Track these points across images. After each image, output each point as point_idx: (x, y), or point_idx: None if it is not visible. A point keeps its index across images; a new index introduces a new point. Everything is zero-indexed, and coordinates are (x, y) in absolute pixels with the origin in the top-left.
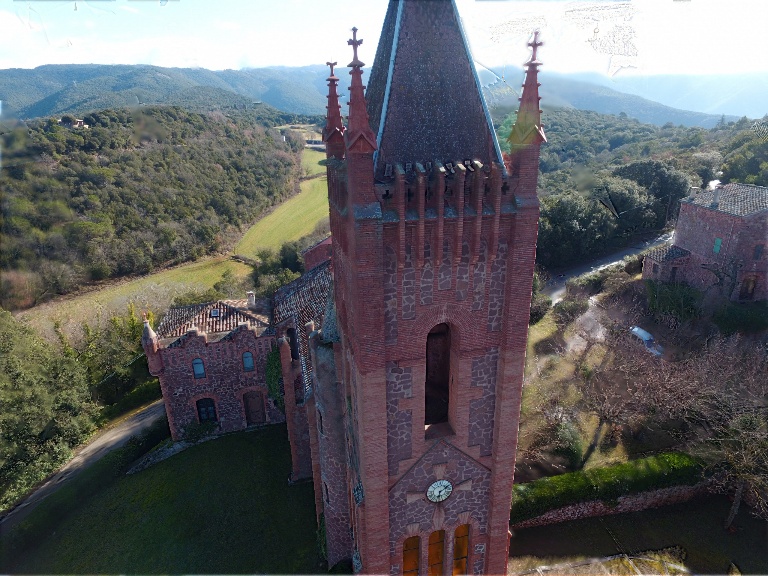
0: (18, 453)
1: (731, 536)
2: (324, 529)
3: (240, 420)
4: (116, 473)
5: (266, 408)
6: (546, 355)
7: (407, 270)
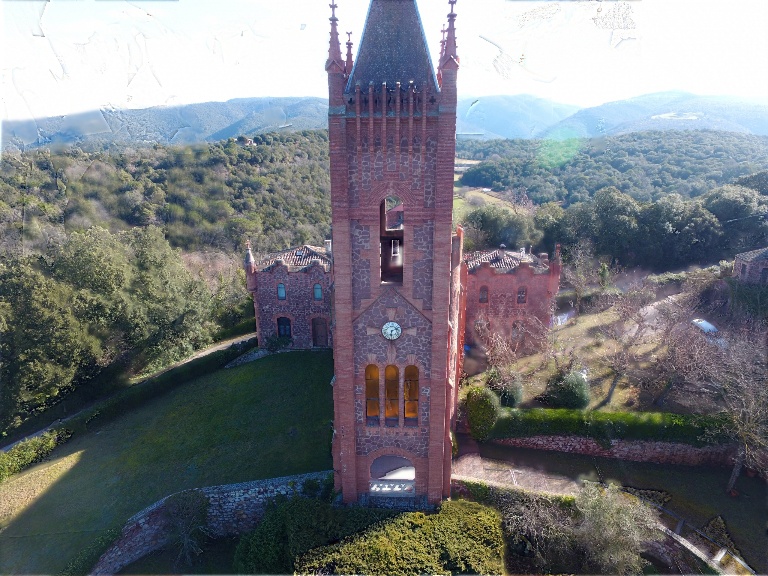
0: (159, 333)
1: (730, 498)
2: None
3: (308, 340)
4: (218, 366)
5: (328, 334)
6: None
7: (365, 154)
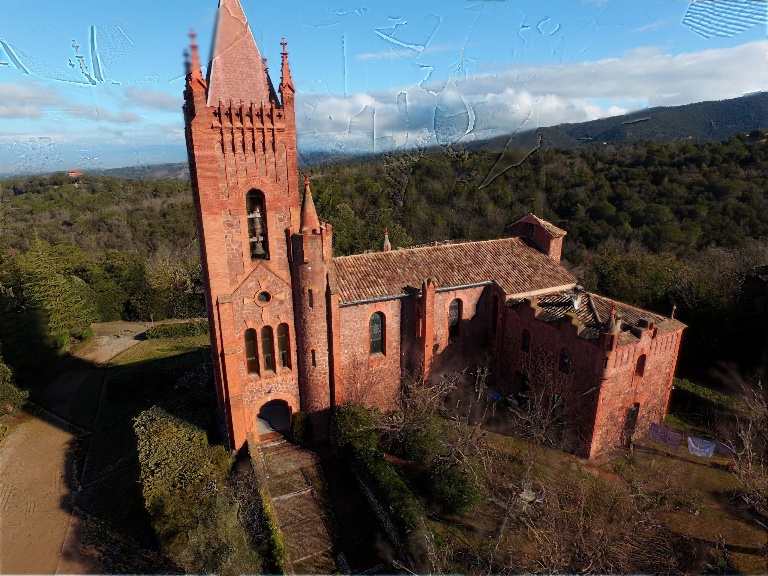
0: None
1: None
2: None
3: None
4: None
5: None
6: (729, 504)
7: None
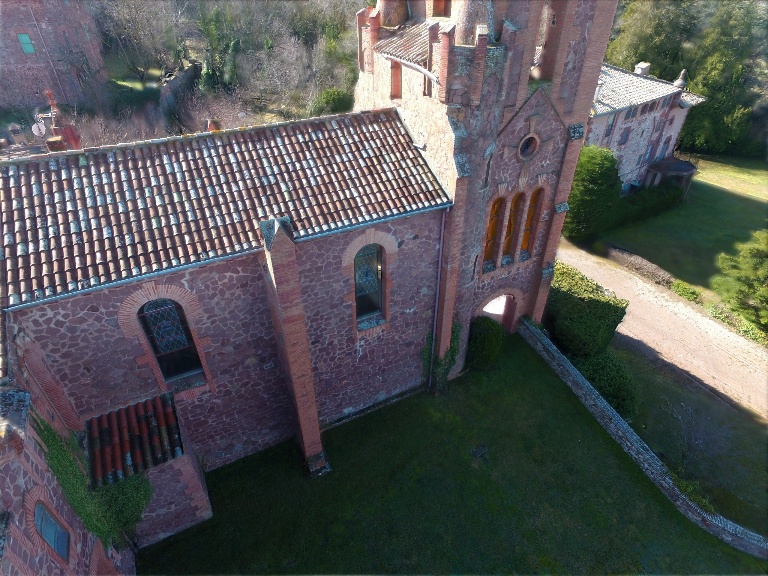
0: None
1: None
2: (459, 330)
3: None
4: None
5: None
6: None
7: None
